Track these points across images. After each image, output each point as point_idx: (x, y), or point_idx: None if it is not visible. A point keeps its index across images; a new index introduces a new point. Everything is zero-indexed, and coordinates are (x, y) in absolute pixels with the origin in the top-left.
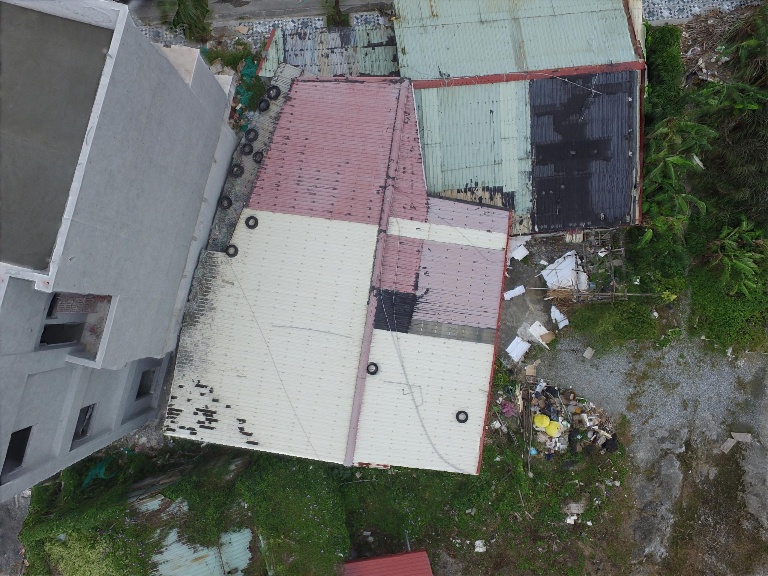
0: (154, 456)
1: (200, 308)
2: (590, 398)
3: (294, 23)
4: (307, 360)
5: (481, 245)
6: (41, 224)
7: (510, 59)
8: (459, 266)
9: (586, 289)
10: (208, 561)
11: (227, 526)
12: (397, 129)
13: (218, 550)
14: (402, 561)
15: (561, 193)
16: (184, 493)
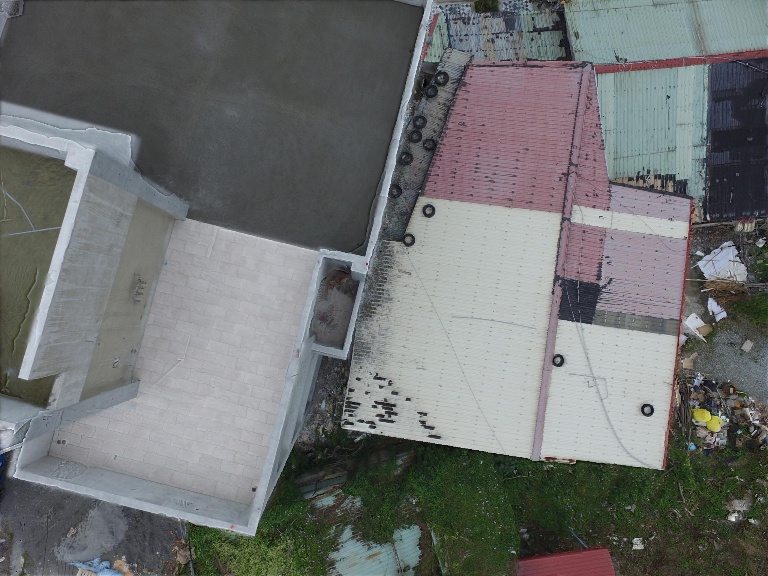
0: (307, 451)
1: (376, 299)
2: (749, 392)
3: (442, 9)
4: (490, 352)
5: (663, 234)
6: (329, 204)
7: (687, 43)
8: (642, 255)
9: (745, 280)
10: (381, 558)
11: (398, 522)
12: (580, 114)
13: (393, 547)
14: (581, 559)
15: (735, 181)
16: (362, 488)
